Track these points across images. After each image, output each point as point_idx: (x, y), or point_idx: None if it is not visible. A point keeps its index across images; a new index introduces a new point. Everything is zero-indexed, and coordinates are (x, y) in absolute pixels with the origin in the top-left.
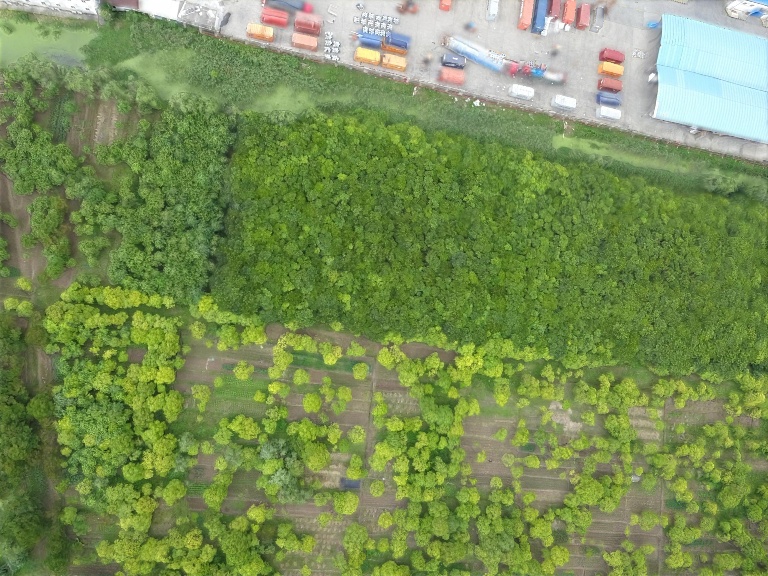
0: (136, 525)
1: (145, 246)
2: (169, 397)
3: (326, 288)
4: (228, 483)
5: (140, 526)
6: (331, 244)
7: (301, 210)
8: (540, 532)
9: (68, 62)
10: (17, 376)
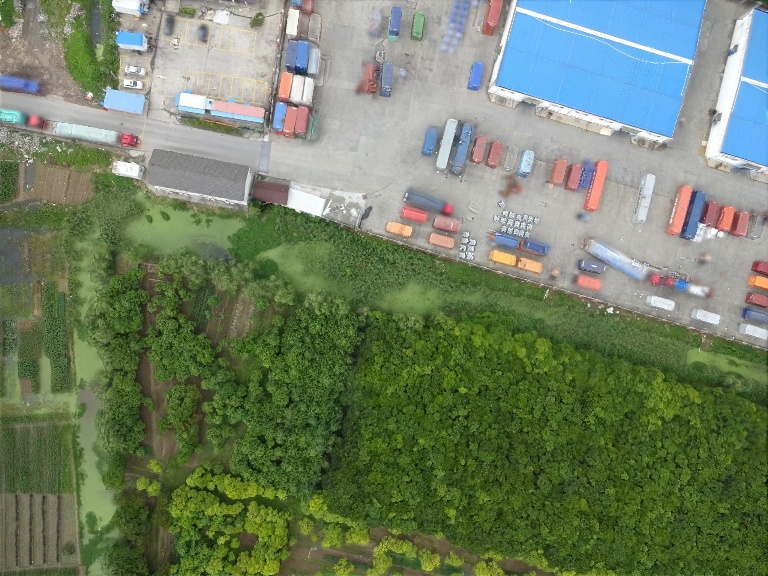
0: None
1: (267, 439)
2: None
3: (433, 502)
4: None
5: None
6: (444, 459)
7: (419, 423)
8: None
9: (216, 249)
10: (141, 554)
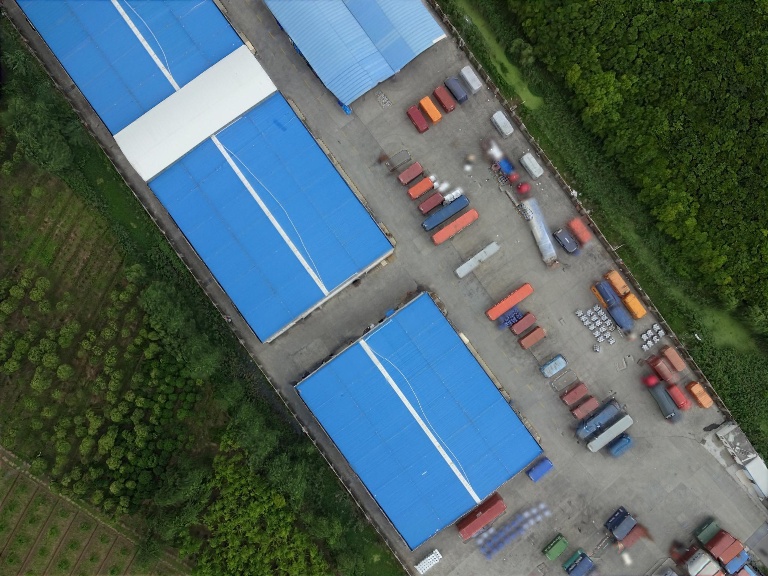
0: None
1: None
2: None
3: None
4: None
5: None
6: None
7: None
8: None
9: None
10: None
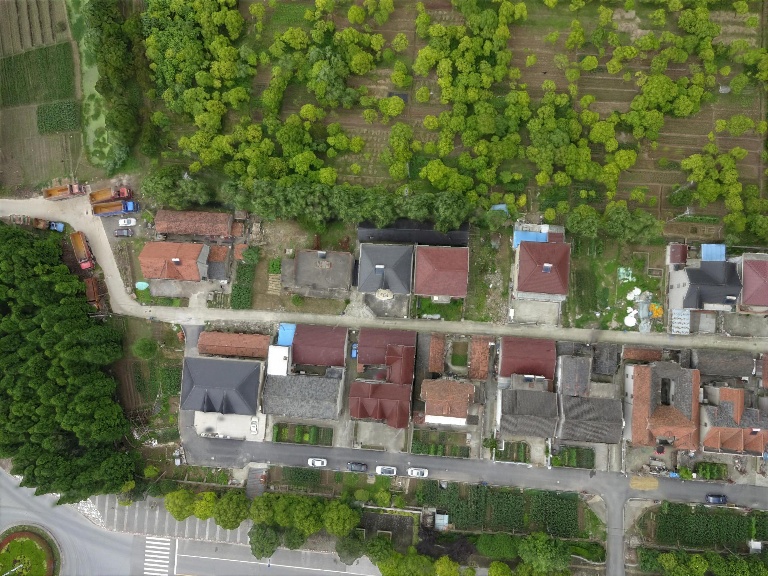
0: (206, 118)
1: None
2: (229, 11)
3: None
4: (282, 86)
5: (210, 120)
6: None
7: None
8: (600, 131)
9: None
10: (114, 4)
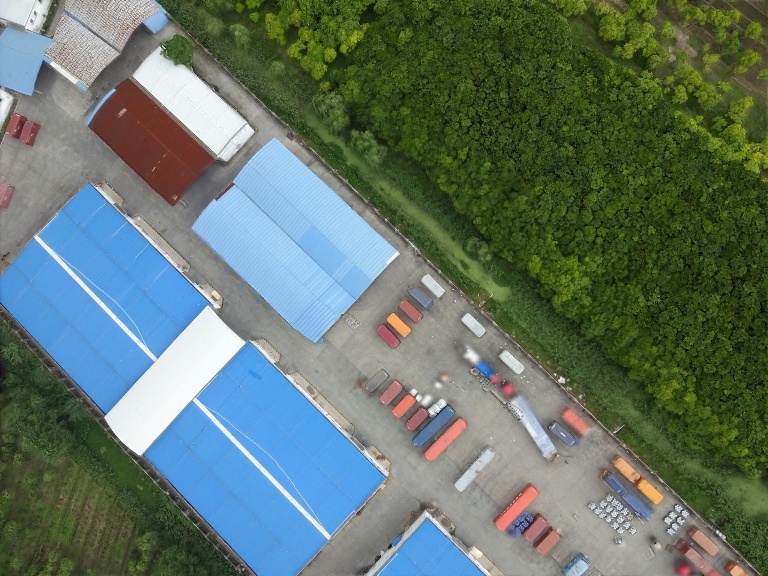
0: None
1: None
2: None
3: None
4: None
5: None
6: None
7: None
8: None
9: None
10: None
